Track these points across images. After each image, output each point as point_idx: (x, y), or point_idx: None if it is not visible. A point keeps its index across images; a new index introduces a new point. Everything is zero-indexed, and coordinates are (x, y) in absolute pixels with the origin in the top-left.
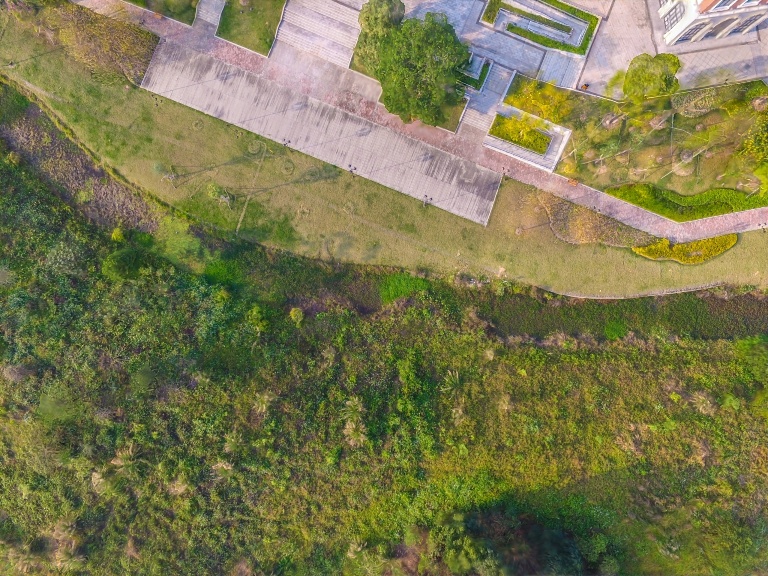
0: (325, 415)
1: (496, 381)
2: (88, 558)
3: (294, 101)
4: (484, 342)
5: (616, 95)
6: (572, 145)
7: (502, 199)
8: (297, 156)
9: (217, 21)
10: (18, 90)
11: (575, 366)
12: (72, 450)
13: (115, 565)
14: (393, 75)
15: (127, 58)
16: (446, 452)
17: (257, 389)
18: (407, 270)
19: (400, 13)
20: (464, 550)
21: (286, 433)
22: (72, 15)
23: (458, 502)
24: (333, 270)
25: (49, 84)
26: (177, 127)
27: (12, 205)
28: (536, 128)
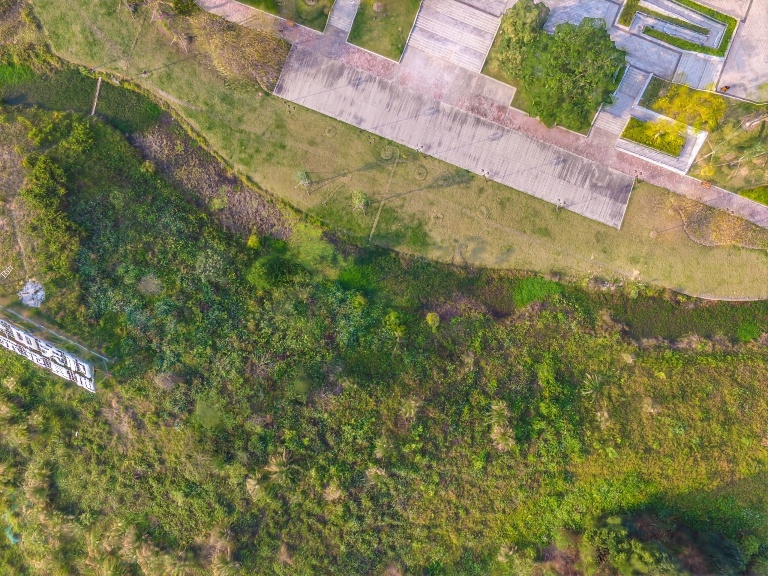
0: (470, 420)
1: (635, 384)
2: (241, 564)
3: (426, 106)
4: (619, 345)
5: (755, 97)
6: (709, 147)
7: (635, 202)
8: (430, 161)
9: (349, 27)
10: (151, 98)
11: (712, 368)
12: (224, 457)
13: (268, 571)
14: (550, 80)
15: (260, 65)
16: (593, 455)
17: (401, 394)
18: (540, 274)
19: (545, 18)
20: (637, 554)
21: (433, 438)
22: (204, 23)
23: (606, 505)
24: (467, 275)
25: (183, 92)
26: (310, 134)
27: (151, 213)
28: (671, 131)
